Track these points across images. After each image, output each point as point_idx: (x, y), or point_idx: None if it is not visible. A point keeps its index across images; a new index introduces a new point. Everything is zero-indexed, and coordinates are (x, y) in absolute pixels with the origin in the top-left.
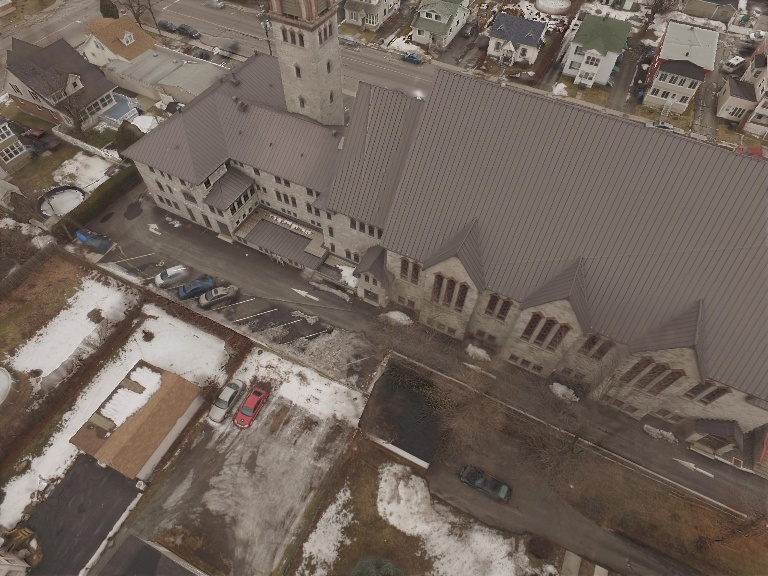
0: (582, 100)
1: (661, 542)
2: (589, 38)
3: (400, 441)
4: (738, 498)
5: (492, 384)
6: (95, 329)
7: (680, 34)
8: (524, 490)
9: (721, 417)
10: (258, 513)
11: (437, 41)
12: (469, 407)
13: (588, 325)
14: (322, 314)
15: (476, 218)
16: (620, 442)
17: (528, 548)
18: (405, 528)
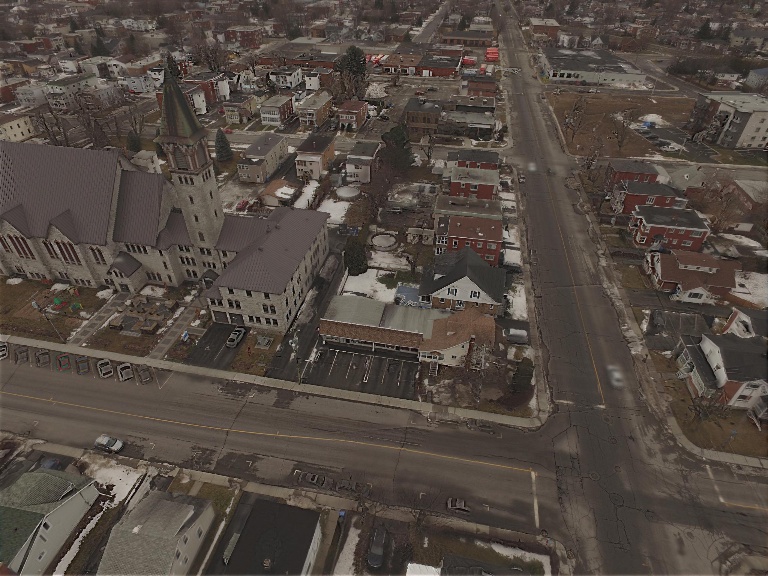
0: None
1: None
2: None
3: None
4: None
5: None
6: (314, 202)
7: None
8: None
9: None
10: None
11: None
12: None
13: None
14: None
15: None
16: None
17: None
18: None
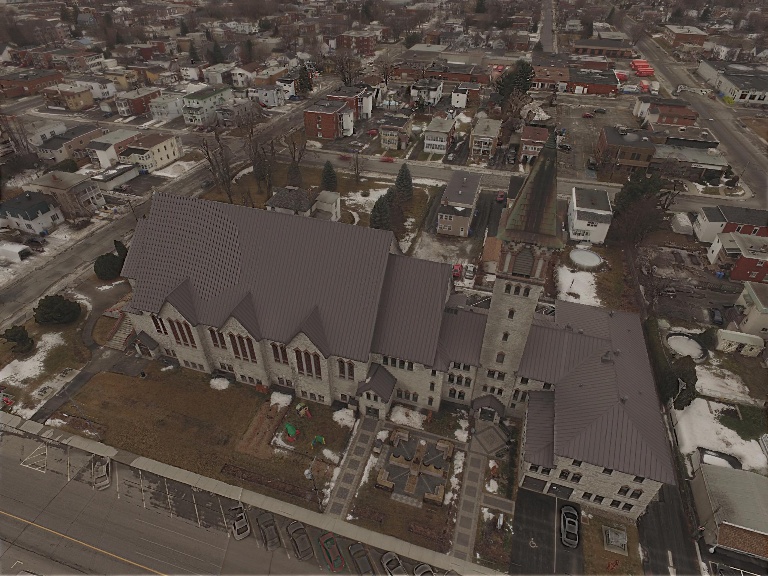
0: None
1: None
2: None
3: None
4: None
5: None
6: None
7: None
8: None
9: None
10: (434, 247)
11: None
12: None
13: None
14: None
15: None
16: None
17: None
18: None
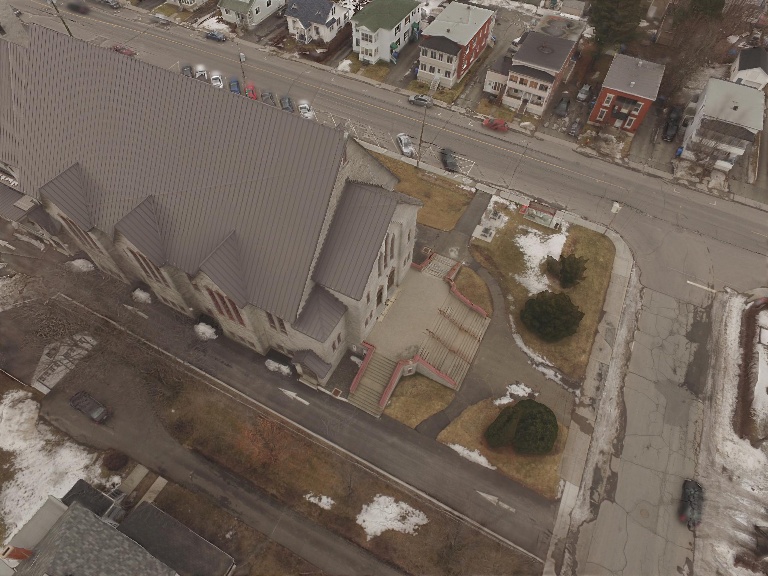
0: (362, 75)
1: (231, 458)
2: (365, 16)
3: (7, 366)
4: (321, 422)
5: (141, 323)
6: None
7: (455, 13)
8: (127, 413)
9: (303, 347)
10: None
11: (243, 20)
12: (111, 343)
13: (164, 258)
14: (12, 261)
15: (77, 161)
16: (236, 374)
17: (105, 462)
18: (3, 444)
